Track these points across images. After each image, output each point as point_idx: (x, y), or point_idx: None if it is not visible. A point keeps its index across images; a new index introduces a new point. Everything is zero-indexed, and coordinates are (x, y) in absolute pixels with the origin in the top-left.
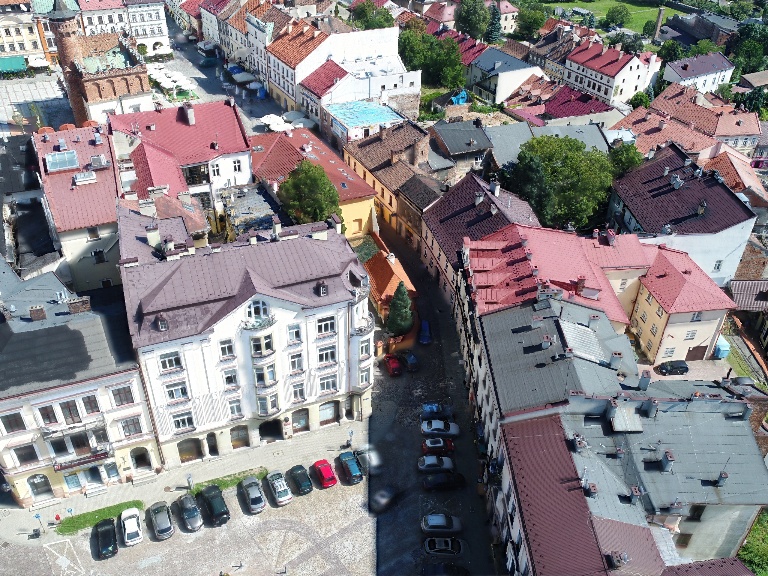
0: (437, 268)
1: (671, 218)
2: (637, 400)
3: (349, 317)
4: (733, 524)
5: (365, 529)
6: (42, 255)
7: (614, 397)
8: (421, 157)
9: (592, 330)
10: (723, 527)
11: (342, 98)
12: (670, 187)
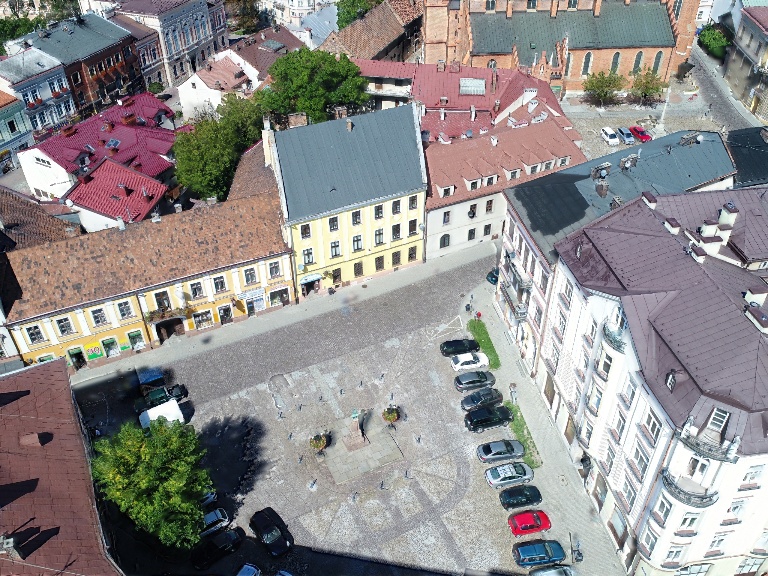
0: None
1: None
2: None
3: (671, 446)
4: None
5: (449, 560)
6: None
7: None
8: None
9: None
10: None
11: None
12: None
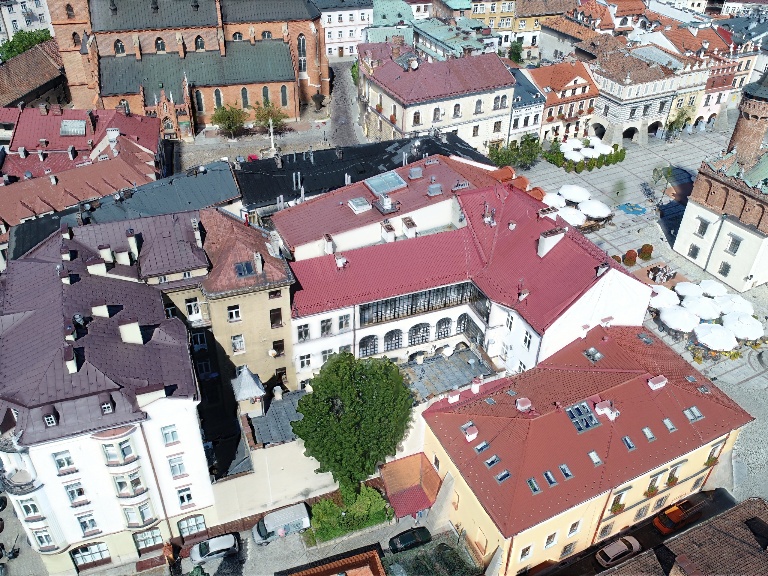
0: None
1: None
2: None
3: None
4: None
5: None
6: None
7: None
8: None
9: None
10: None
11: None
12: None
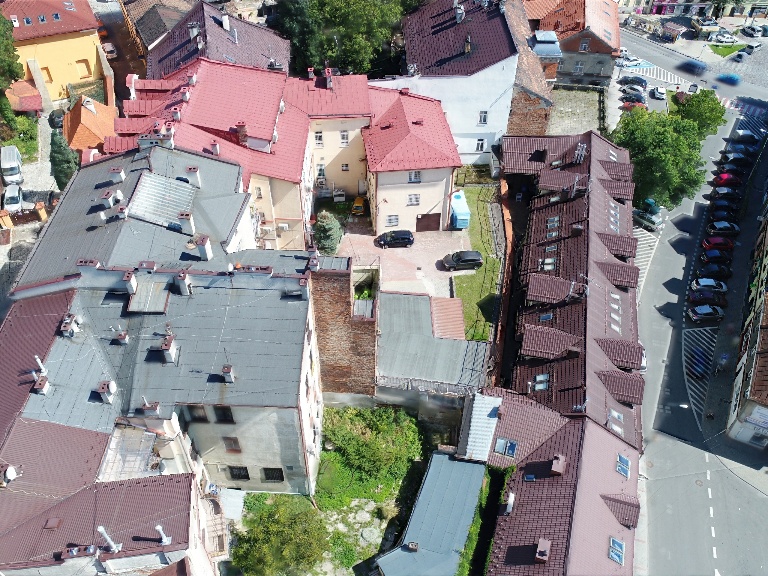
0: None
1: (438, 58)
2: (164, 272)
3: None
4: (279, 427)
5: None
6: None
7: (136, 268)
8: None
9: (192, 186)
10: (269, 430)
11: None
12: (453, 21)
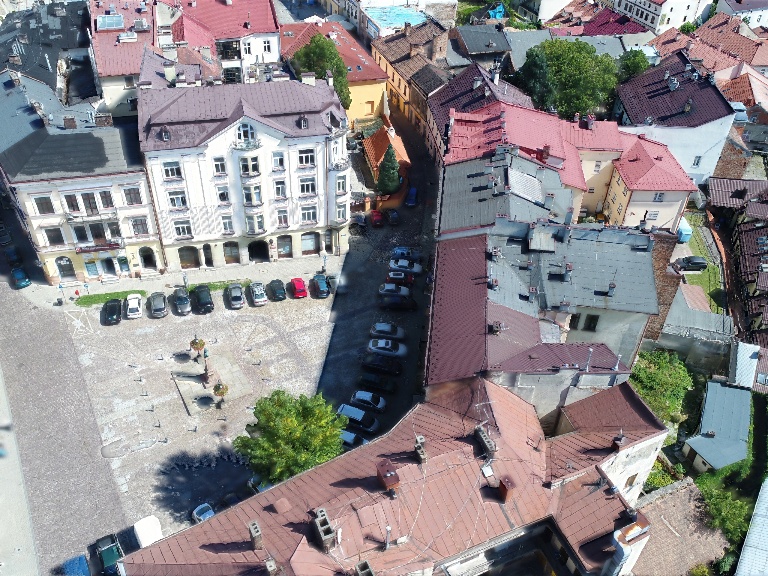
0: (435, 148)
1: (660, 115)
2: (554, 226)
3: (327, 152)
4: (625, 337)
5: (323, 329)
6: (87, 98)
7: (534, 222)
8: (439, 53)
9: (538, 180)
10: (616, 340)
11: (380, 2)
12: (667, 89)
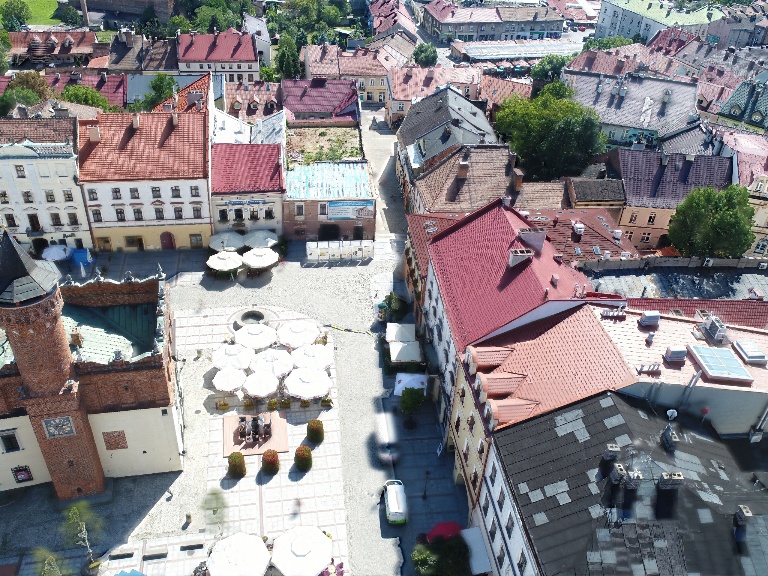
0: None
1: (655, 114)
2: None
3: None
4: None
5: None
6: None
7: None
8: None
9: None
10: None
11: None
12: (618, 97)
